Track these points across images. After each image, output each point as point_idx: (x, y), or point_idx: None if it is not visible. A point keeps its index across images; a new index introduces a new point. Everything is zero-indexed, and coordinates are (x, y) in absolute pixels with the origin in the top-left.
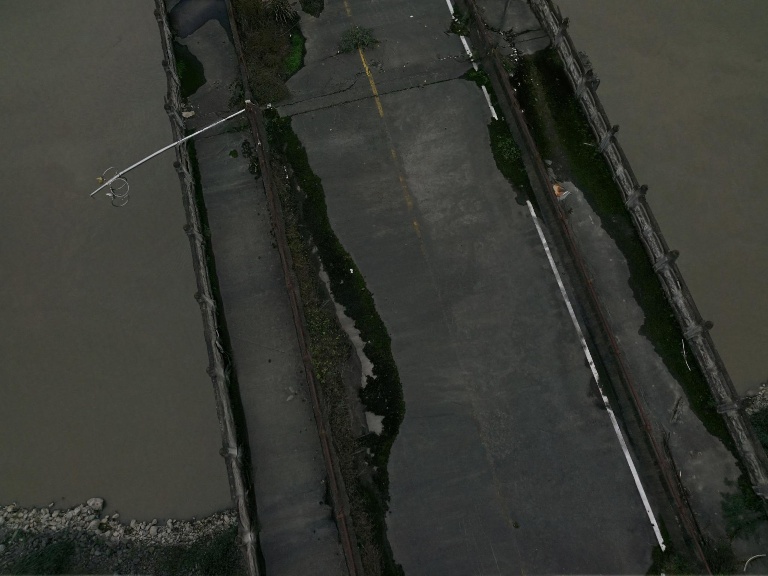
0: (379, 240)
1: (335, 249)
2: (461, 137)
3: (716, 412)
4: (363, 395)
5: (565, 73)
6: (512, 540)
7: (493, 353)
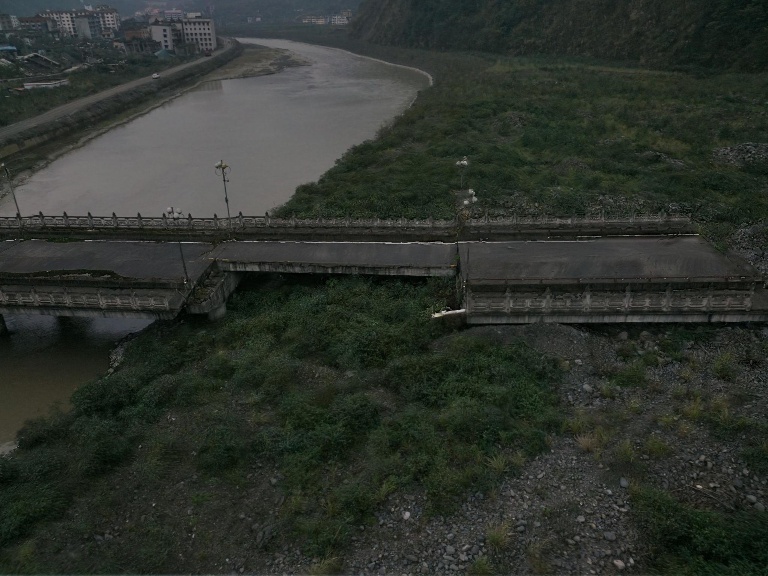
0: (47, 265)
1: (34, 273)
2: (41, 246)
3: (191, 229)
4: (93, 276)
5: (56, 227)
6: (176, 261)
7: (120, 254)
